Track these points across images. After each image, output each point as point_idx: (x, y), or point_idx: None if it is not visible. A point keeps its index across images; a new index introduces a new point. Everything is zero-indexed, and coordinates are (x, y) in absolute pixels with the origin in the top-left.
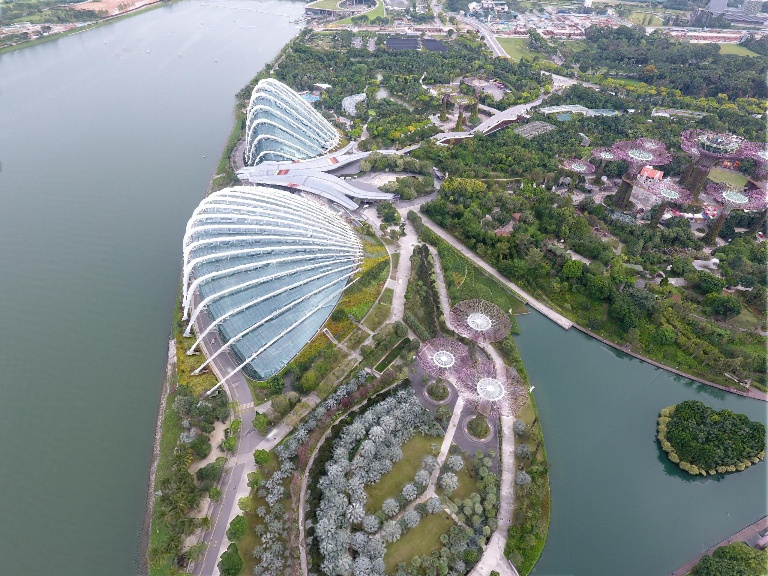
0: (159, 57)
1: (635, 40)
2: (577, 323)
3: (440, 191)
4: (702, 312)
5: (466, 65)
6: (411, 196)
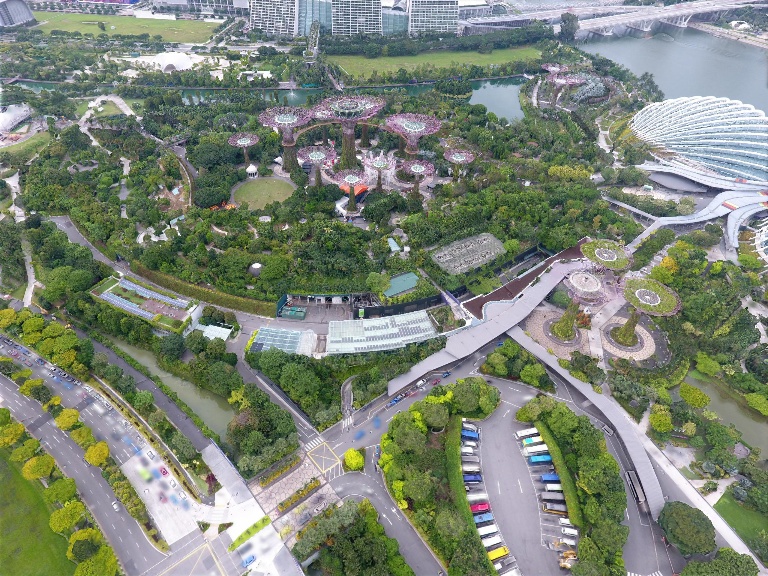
0: None
1: None
2: None
3: None
4: None
5: None
6: None
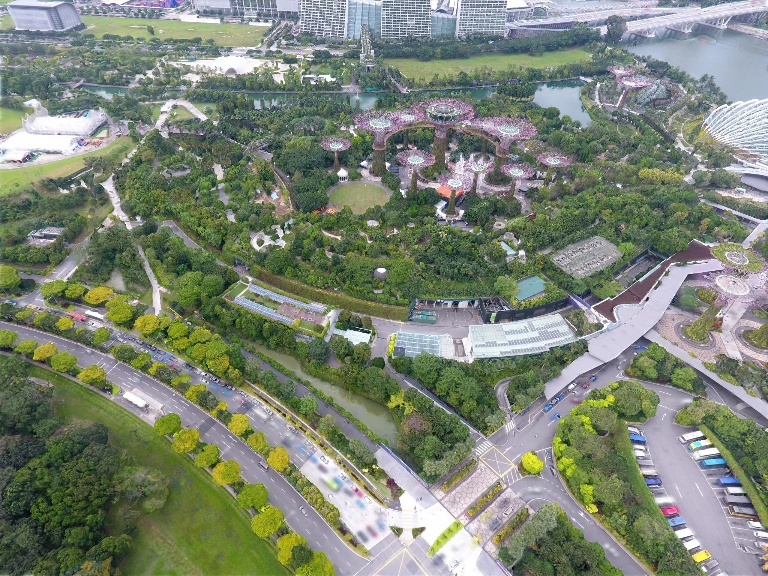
0: None
1: None
2: None
3: None
4: None
5: None
6: None
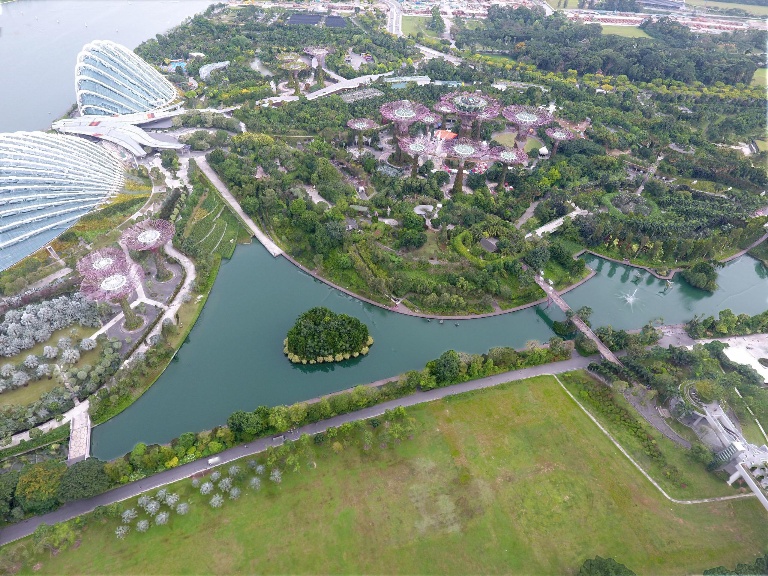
0: (66, 27)
1: (533, 20)
2: (286, 252)
3: (230, 143)
4: (395, 245)
5: (345, 39)
6: (201, 147)
